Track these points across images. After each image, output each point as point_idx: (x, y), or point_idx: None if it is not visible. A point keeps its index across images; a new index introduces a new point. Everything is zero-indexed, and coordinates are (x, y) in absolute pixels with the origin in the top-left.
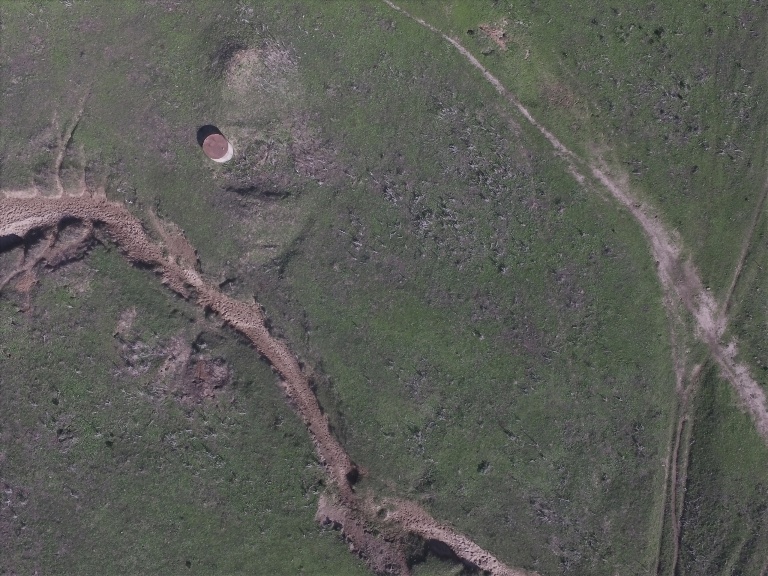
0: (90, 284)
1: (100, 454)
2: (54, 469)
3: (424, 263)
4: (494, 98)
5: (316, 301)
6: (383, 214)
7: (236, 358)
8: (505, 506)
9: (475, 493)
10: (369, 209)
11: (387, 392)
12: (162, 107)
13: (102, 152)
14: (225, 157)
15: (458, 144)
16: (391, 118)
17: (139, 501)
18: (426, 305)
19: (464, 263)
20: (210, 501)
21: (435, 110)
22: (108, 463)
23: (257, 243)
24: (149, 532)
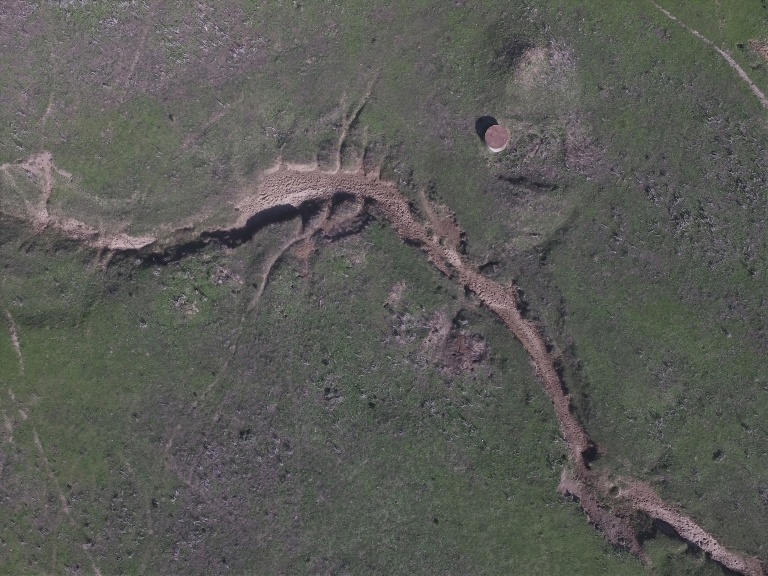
0: (366, 256)
1: (363, 414)
2: (320, 424)
3: (678, 261)
4: (758, 110)
5: (574, 289)
6: (643, 212)
7: (493, 336)
8: (735, 494)
9: (708, 479)
10: (630, 206)
11: (634, 379)
12: (445, 96)
13: (385, 134)
14: (502, 147)
15: (720, 151)
16: (658, 122)
17: (395, 460)
18: (678, 301)
19: (716, 264)
20: (460, 466)
21: (700, 117)
22: (370, 423)
23: (523, 230)
24: (403, 489)
